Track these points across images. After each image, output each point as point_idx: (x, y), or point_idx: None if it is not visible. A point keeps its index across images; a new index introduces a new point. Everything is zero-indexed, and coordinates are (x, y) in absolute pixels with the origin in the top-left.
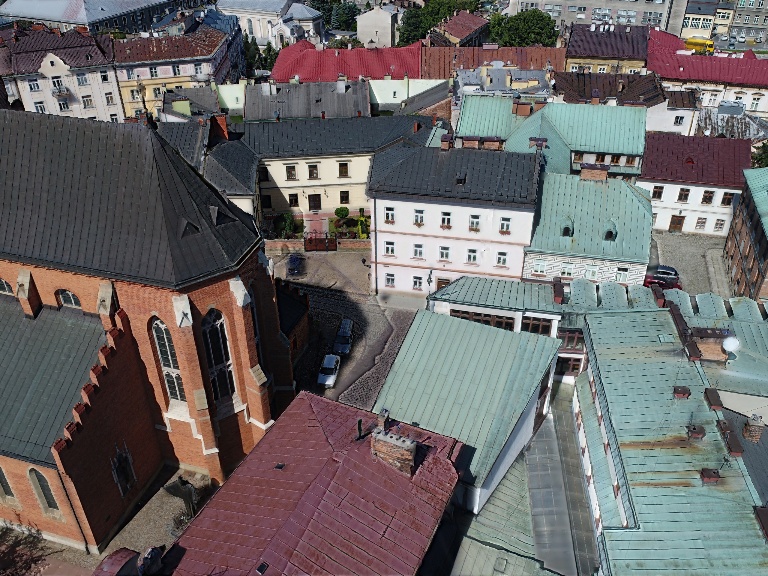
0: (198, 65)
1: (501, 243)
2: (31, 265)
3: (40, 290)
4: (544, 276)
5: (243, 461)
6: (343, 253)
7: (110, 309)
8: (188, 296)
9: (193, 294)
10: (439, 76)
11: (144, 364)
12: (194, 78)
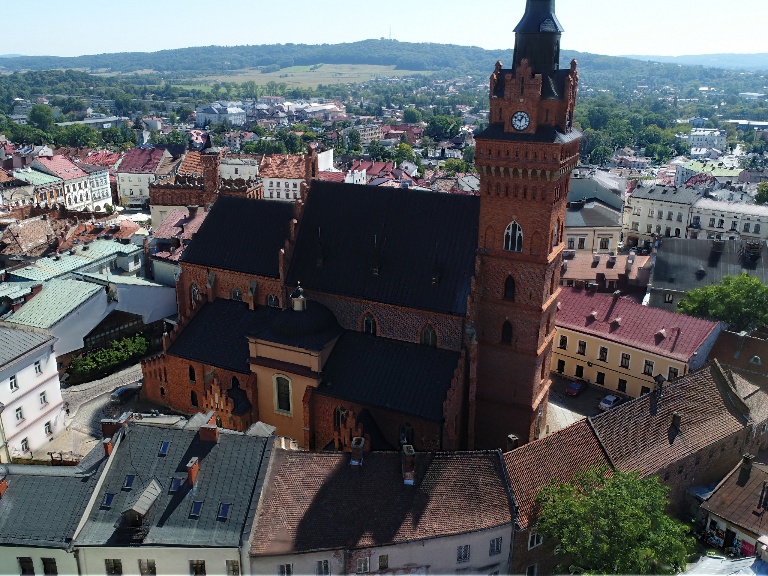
0: None
1: None
2: None
3: None
4: None
5: None
6: None
7: None
8: None
9: None
10: None
11: None
12: None
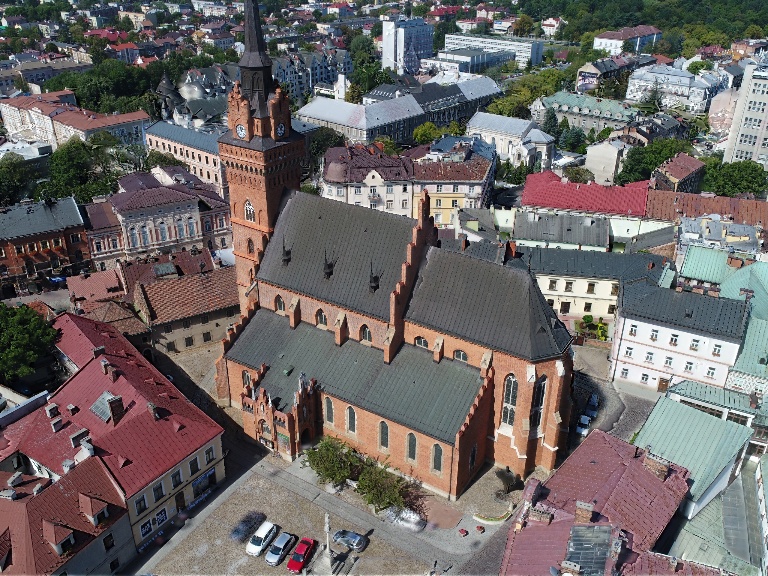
0: (472, 186)
1: (712, 361)
2: (447, 334)
3: (445, 348)
4: (741, 389)
5: (570, 457)
6: (587, 348)
7: (488, 365)
8: (535, 366)
9: (538, 365)
10: (661, 214)
11: (494, 399)
12: (467, 195)
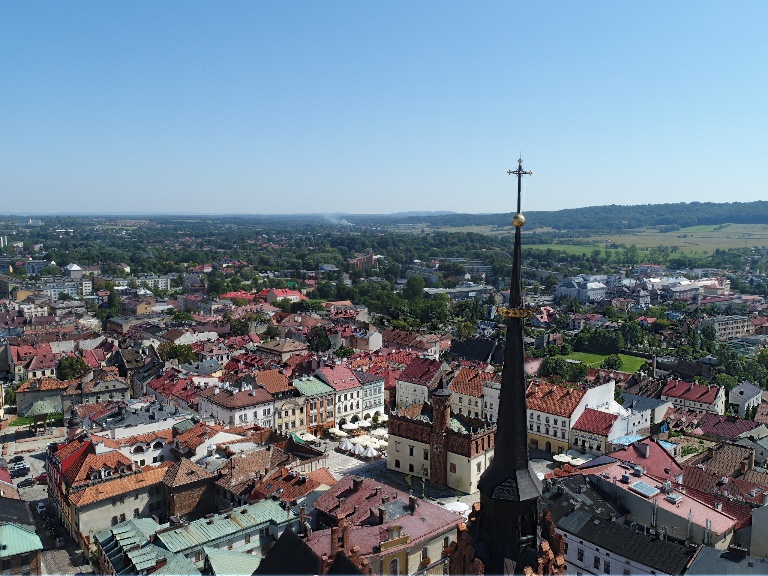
0: None
1: None
2: None
3: None
4: None
5: None
6: None
7: None
8: None
9: None
10: None
11: None
12: None
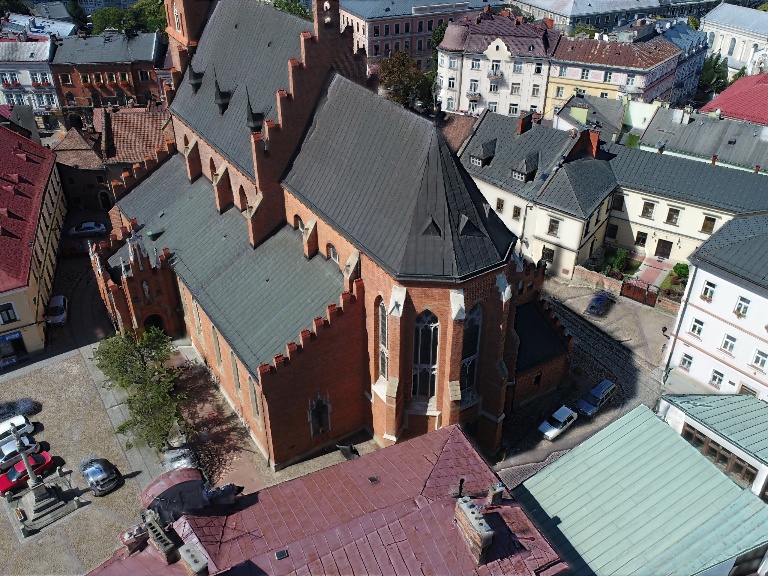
0: (632, 76)
1: None
2: (317, 215)
3: (320, 238)
4: None
5: None
6: (659, 312)
7: (351, 275)
8: (407, 290)
9: (413, 290)
10: None
11: (367, 334)
12: (623, 88)
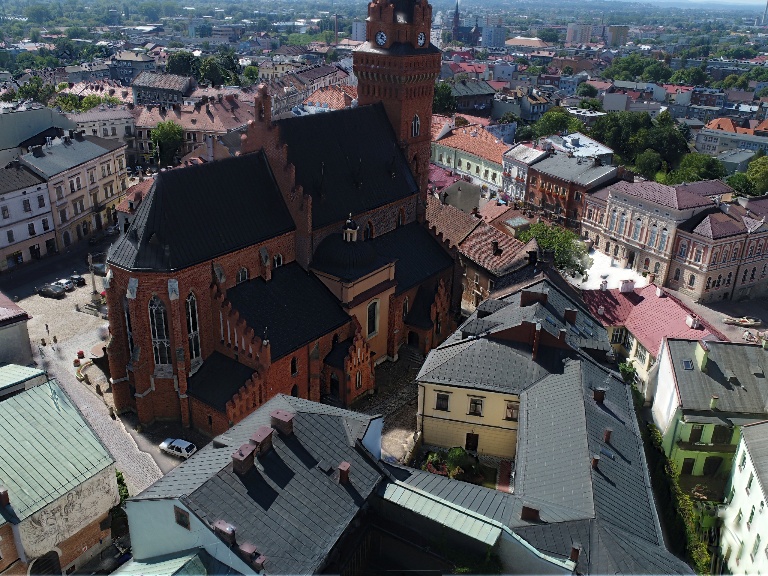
0: None
1: None
2: None
3: None
4: None
5: None
6: None
7: None
8: None
9: None
10: None
11: None
12: None
